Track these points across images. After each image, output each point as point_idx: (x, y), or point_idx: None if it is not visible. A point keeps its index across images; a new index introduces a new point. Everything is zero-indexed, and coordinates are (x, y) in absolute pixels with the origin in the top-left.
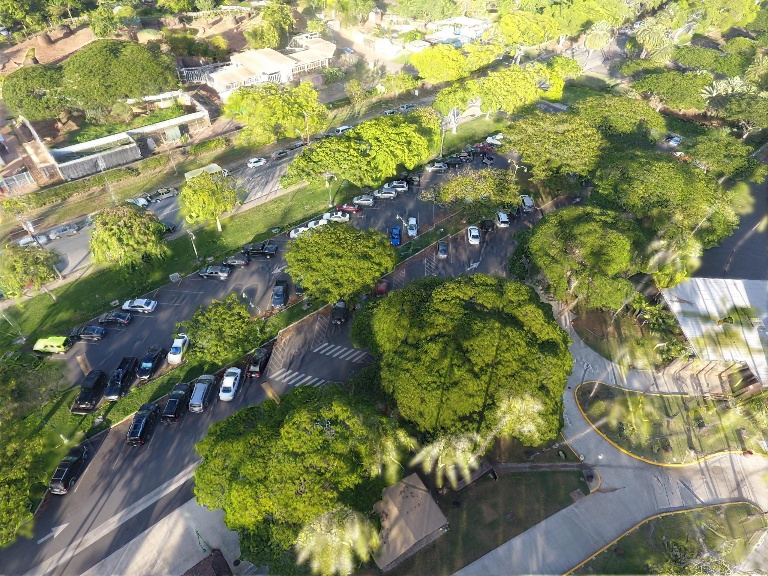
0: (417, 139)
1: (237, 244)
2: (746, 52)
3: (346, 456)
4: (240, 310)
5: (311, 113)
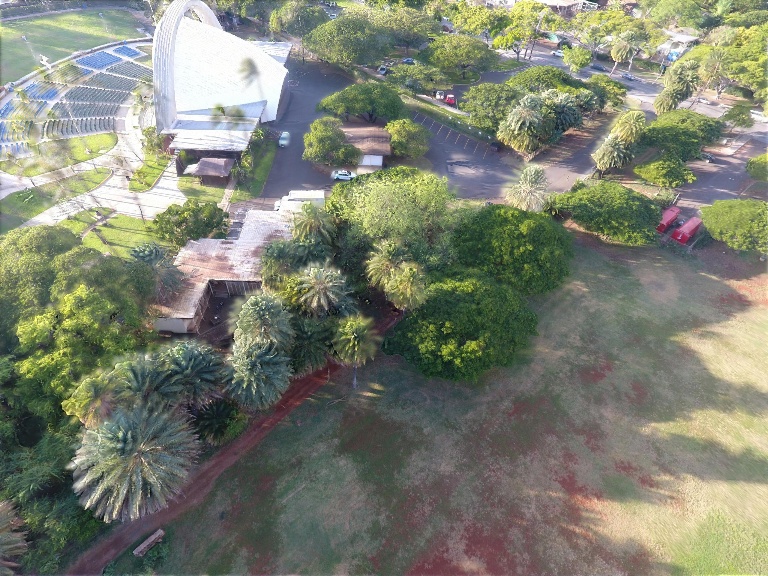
0: (401, 3)
1: (340, 5)
2: (759, 165)
3: None
4: None
5: None
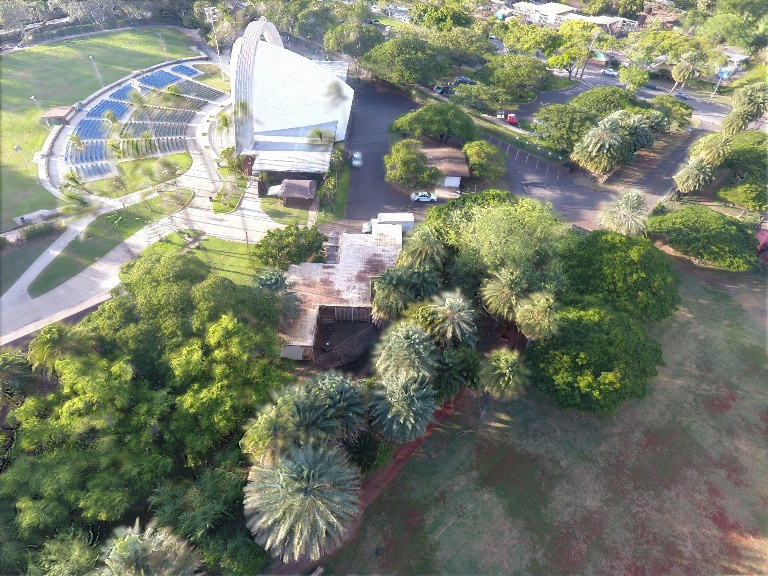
0: None
1: None
2: None
3: (268, 1)
4: (328, 5)
5: (462, 4)
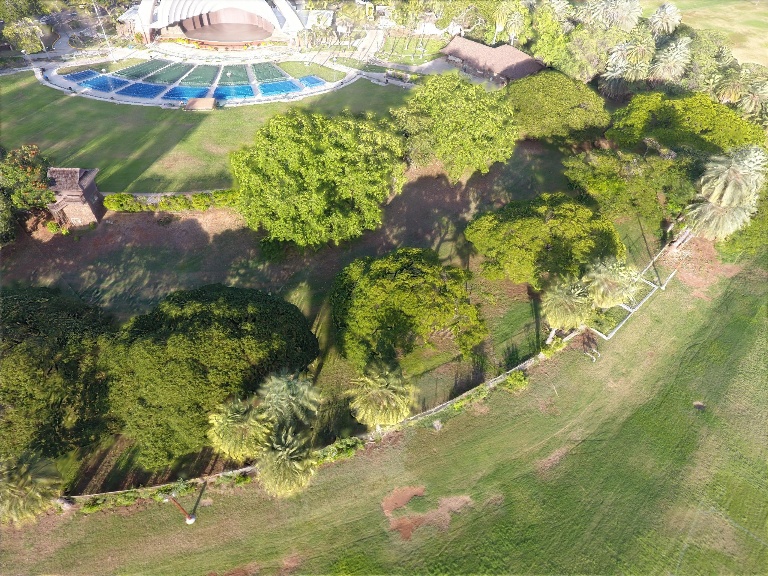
0: None
1: None
2: None
3: None
4: None
5: None
